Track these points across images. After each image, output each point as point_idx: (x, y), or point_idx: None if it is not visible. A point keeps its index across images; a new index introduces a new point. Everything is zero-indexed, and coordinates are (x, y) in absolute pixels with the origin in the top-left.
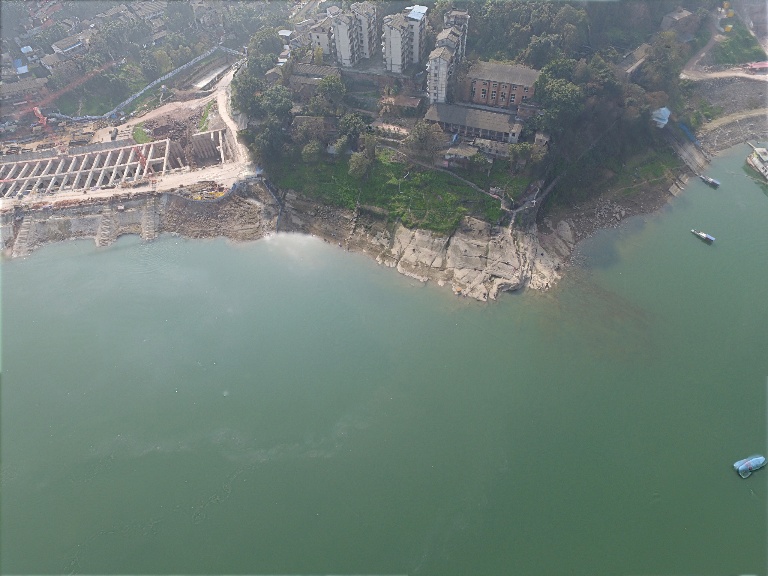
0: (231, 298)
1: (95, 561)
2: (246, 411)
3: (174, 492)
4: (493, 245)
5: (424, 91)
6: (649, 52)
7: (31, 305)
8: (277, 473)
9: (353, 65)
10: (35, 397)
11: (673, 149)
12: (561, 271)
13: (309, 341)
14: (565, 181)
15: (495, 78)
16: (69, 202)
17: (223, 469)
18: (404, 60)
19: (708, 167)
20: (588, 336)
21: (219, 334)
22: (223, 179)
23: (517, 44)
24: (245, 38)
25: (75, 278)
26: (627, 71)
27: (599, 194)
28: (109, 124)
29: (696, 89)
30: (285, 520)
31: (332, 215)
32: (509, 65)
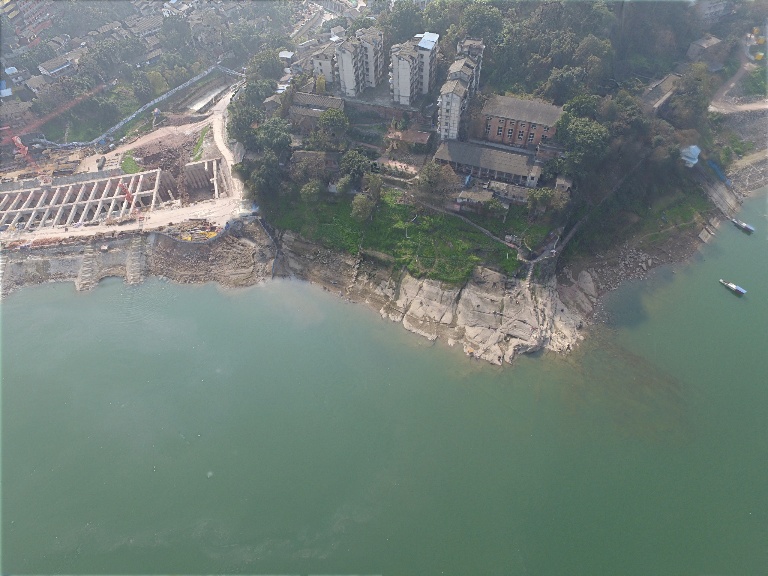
0: (220, 356)
1: None
2: (232, 496)
3: None
4: (509, 300)
5: (434, 125)
6: (677, 85)
7: (1, 359)
8: None
9: (358, 95)
10: None
11: (703, 190)
12: (583, 330)
13: (304, 410)
14: (587, 226)
15: (512, 115)
16: (48, 241)
17: (203, 570)
18: (413, 91)
19: (740, 209)
20: (615, 410)
21: (205, 400)
22: (216, 216)
23: (536, 76)
24: (245, 57)
25: (51, 327)
26: (654, 106)
27: (623, 241)
28: (97, 151)
29: (726, 123)
30: None
31: (332, 260)
32: (527, 100)
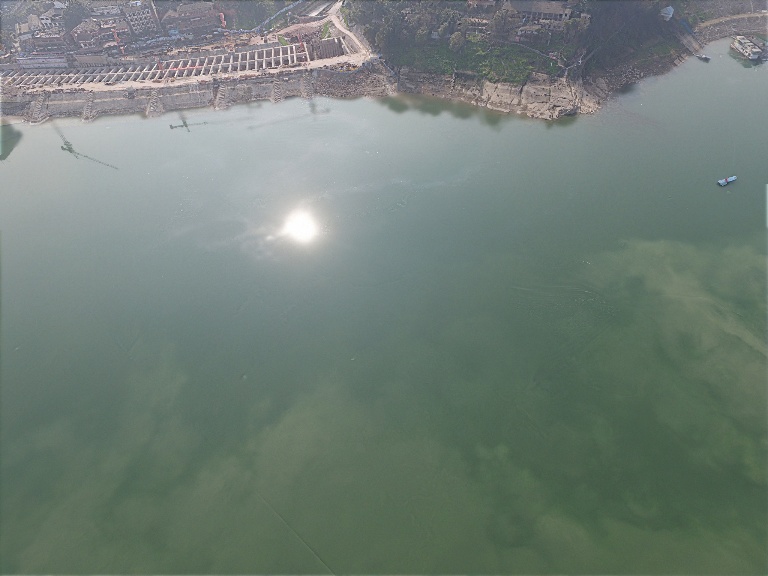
0: (377, 123)
1: (336, 229)
2: (406, 170)
3: (373, 202)
4: (554, 88)
5: None
6: None
7: (240, 132)
8: (434, 193)
9: None
10: (266, 169)
11: (676, 36)
12: (601, 104)
13: (437, 140)
14: (600, 53)
15: None
16: (250, 75)
17: (400, 193)
18: None
19: (702, 50)
20: (622, 134)
21: (376, 139)
22: (354, 62)
23: None
24: None
25: (264, 119)
26: None
27: (624, 62)
28: (258, 35)
29: None
30: (446, 209)
31: (436, 80)
32: None
